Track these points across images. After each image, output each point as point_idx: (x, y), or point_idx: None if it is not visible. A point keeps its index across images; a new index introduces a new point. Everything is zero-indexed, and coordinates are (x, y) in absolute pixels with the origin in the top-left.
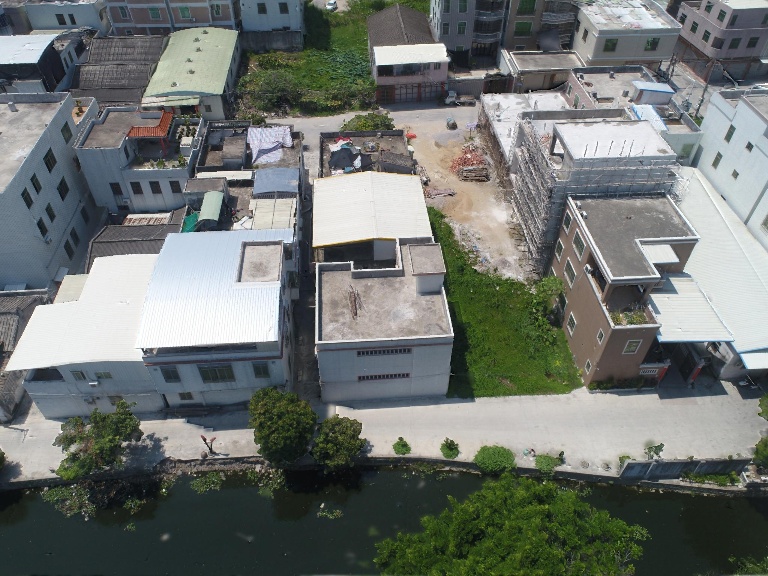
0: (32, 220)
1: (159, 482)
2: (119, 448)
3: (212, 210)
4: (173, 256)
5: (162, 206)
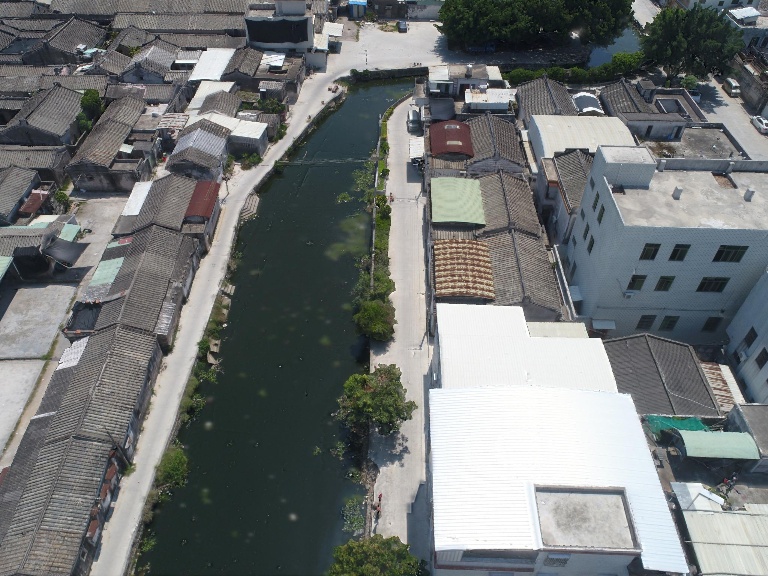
0: (632, 268)
1: (360, 469)
2: (365, 415)
3: (707, 445)
4: (580, 404)
5: (759, 400)
